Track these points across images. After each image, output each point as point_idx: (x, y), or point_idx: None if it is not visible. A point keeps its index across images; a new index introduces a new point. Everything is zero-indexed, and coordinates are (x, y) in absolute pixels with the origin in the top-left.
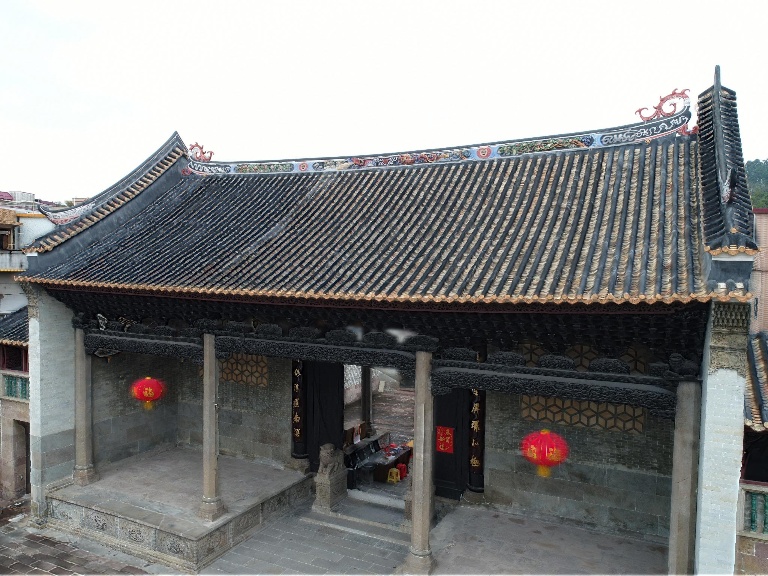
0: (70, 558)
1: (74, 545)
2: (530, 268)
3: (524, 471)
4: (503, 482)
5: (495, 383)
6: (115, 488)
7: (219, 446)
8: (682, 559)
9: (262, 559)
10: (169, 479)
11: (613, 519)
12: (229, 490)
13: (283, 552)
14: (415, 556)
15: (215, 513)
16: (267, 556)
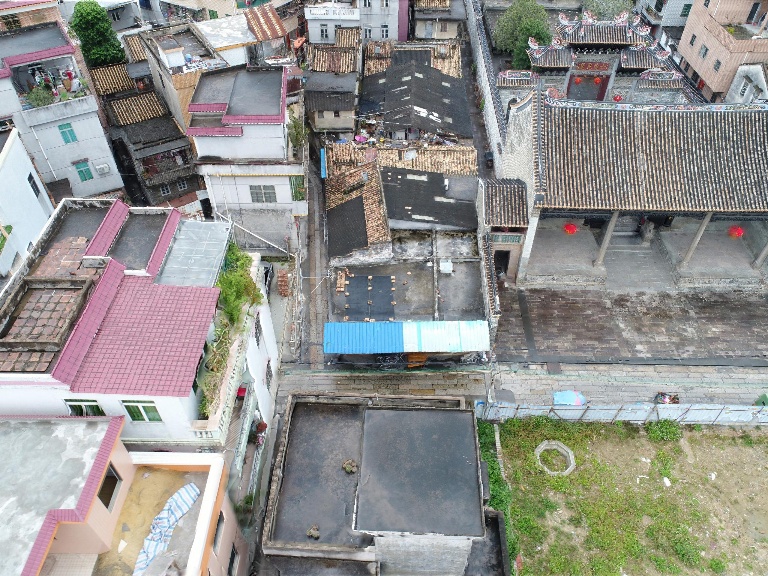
0: (558, 294)
1: (549, 288)
2: (763, 192)
3: (689, 218)
4: (680, 222)
5: (734, 219)
6: (543, 263)
7: (542, 226)
8: (767, 253)
9: (615, 273)
10: (551, 251)
11: (716, 228)
12: (581, 250)
13: (617, 268)
14: (685, 264)
15: (602, 265)
16: (615, 271)
